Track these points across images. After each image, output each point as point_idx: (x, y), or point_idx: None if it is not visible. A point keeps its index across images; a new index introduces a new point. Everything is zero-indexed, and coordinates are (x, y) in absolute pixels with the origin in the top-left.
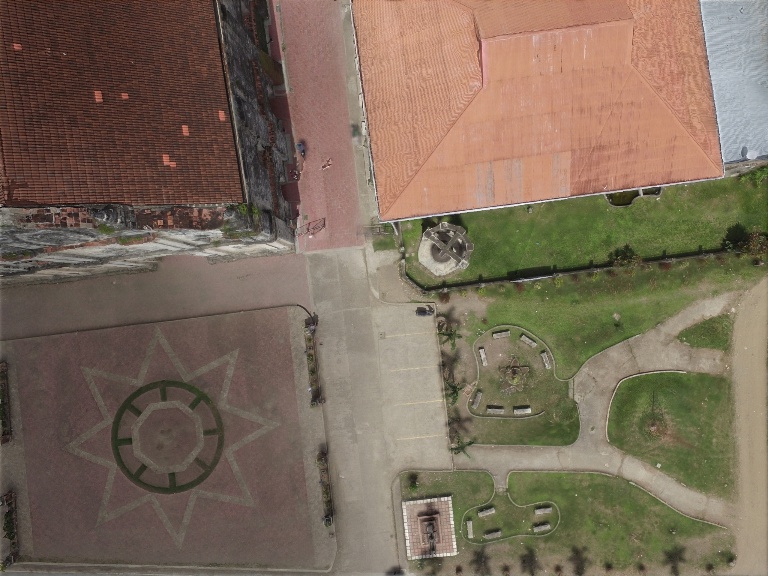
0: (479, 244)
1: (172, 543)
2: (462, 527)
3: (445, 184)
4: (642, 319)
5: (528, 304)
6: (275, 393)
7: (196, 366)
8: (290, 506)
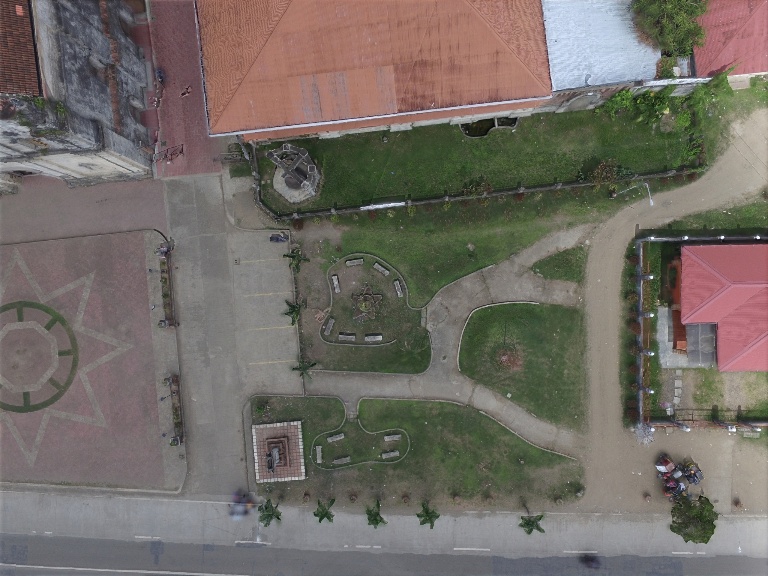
0: (334, 172)
1: (25, 461)
2: (312, 452)
3: (270, 97)
4: (496, 250)
5: (382, 233)
6: (129, 315)
7: (53, 287)
8: (142, 427)
